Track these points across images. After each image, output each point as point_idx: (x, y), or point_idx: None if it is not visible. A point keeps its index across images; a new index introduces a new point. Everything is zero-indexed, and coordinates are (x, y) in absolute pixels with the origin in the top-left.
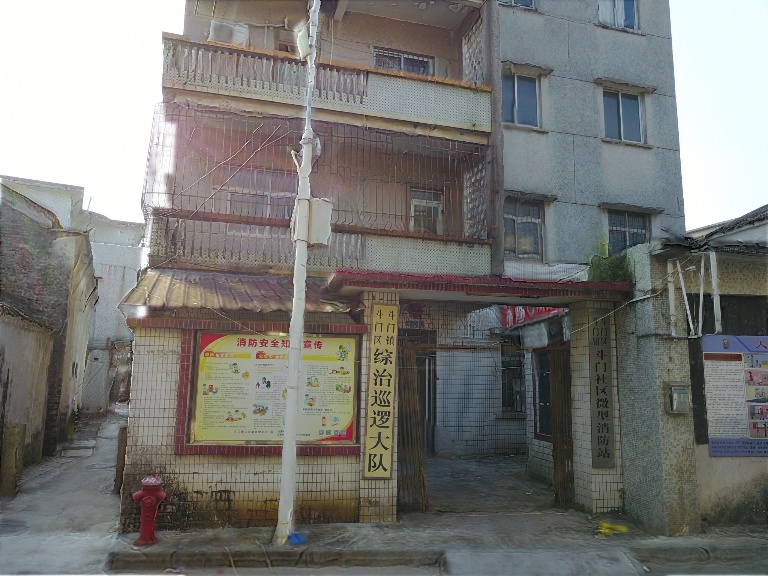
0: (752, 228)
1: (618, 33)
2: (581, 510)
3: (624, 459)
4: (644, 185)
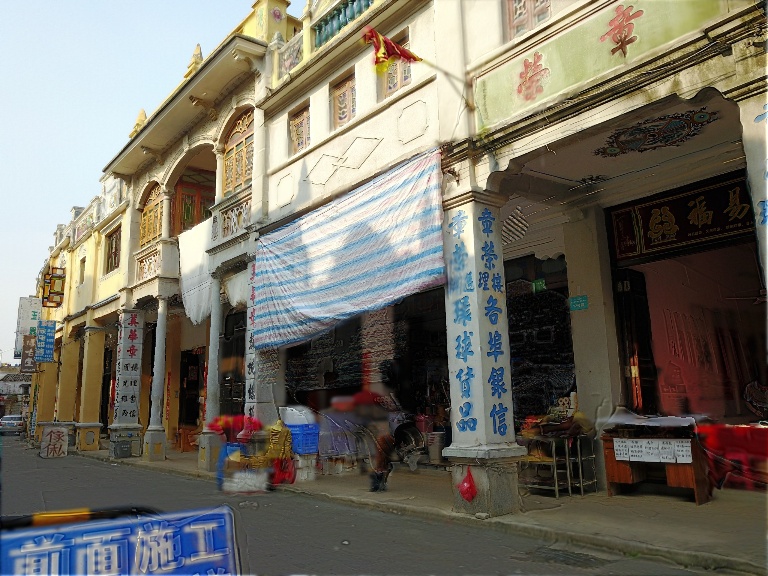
0: (10, 382)
1: None
2: None
3: None
4: None
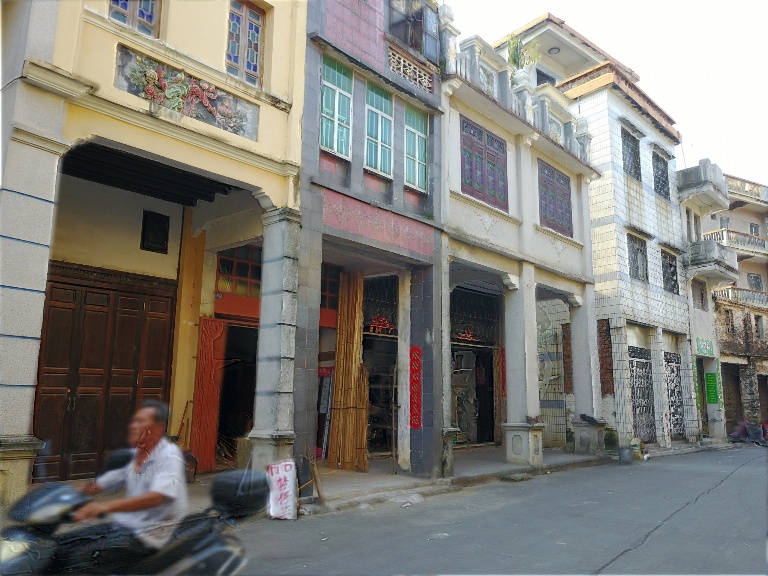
0: None
1: None
2: None
3: None
4: None
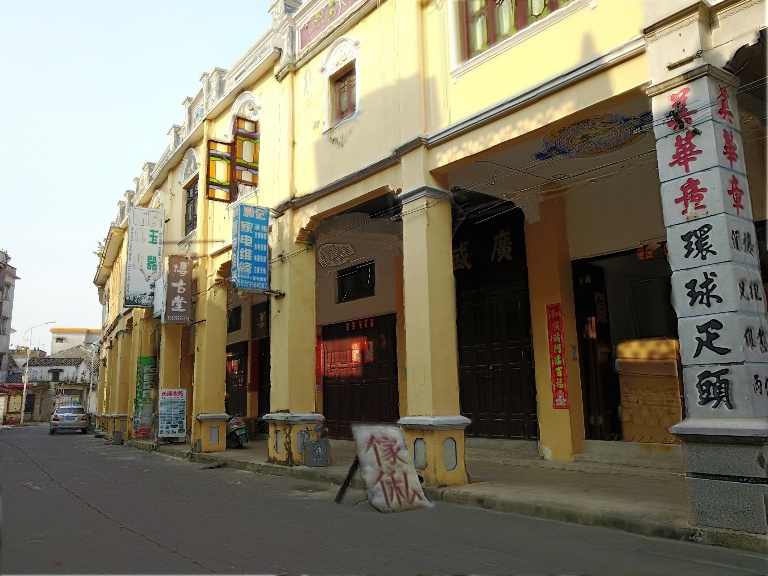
0: (36, 366)
1: (5, 300)
2: (36, 421)
3: (42, 413)
4: (3, 346)
